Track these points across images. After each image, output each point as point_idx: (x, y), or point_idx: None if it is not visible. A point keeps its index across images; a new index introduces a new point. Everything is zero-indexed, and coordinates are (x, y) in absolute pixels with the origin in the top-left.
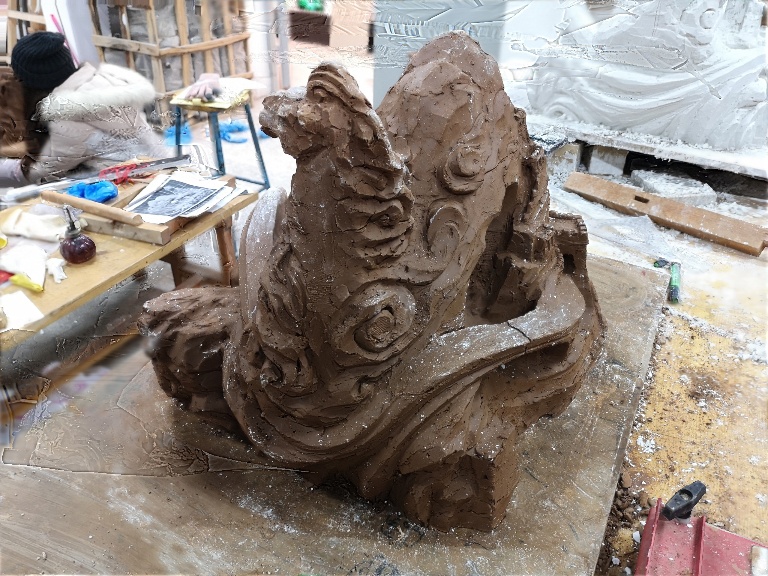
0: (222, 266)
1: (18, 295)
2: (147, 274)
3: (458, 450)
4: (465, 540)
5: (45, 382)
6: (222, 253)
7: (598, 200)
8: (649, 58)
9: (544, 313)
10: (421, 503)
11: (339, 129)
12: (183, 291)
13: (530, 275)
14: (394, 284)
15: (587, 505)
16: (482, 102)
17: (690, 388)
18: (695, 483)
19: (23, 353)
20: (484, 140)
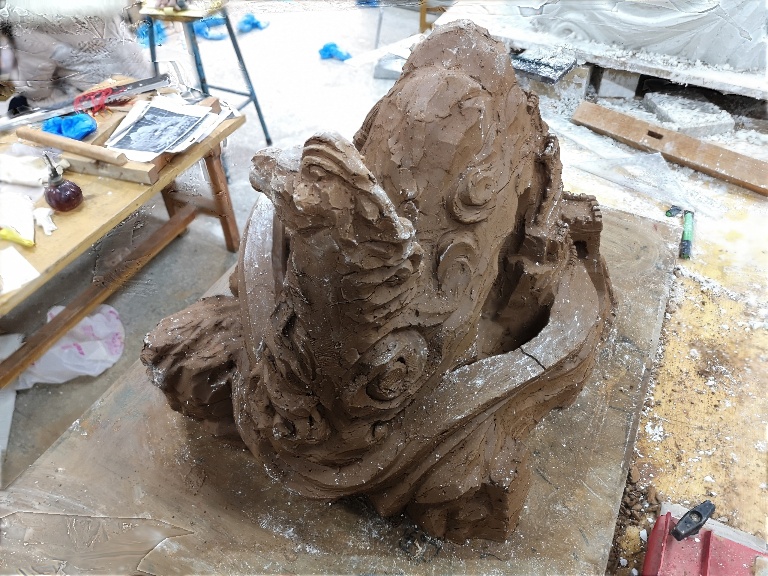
0: (215, 195)
1: (10, 252)
2: (139, 212)
3: (474, 487)
4: (480, 552)
5: (61, 563)
6: (213, 182)
7: (608, 134)
8: (675, 2)
9: (557, 326)
10: (437, 523)
11: (341, 209)
12: (183, 314)
13: (542, 279)
14: (404, 330)
15: (597, 507)
16: (493, 110)
17: (699, 364)
18: (705, 504)
19: (33, 535)
20: (496, 156)
